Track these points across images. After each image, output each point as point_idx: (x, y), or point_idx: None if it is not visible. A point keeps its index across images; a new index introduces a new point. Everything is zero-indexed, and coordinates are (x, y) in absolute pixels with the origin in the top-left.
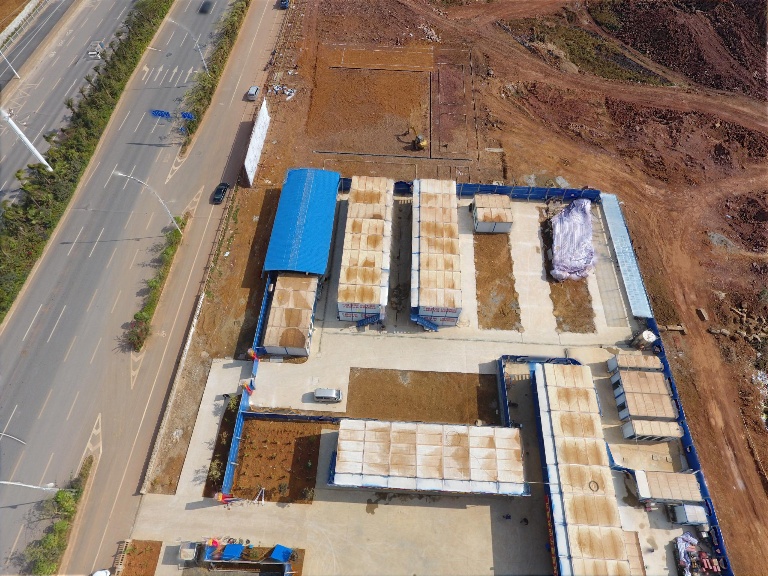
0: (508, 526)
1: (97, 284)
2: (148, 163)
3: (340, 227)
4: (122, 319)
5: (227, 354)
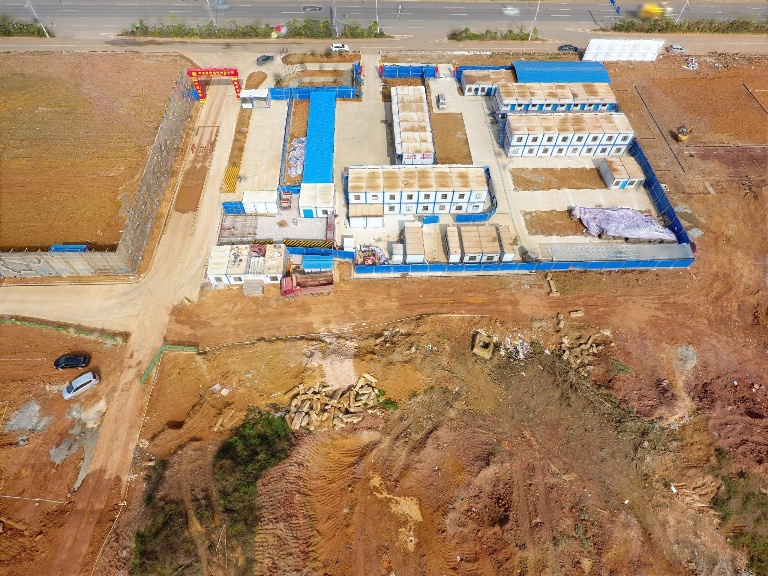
0: None
1: (483, 20)
2: (577, 20)
3: None
4: None
5: None
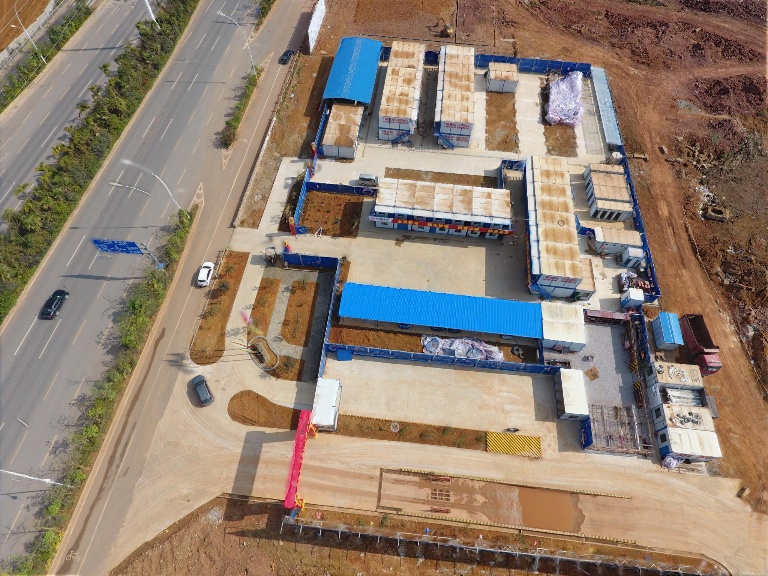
0: (498, 259)
1: (195, 108)
2: (229, 35)
3: (381, 83)
4: (215, 129)
5: (293, 155)
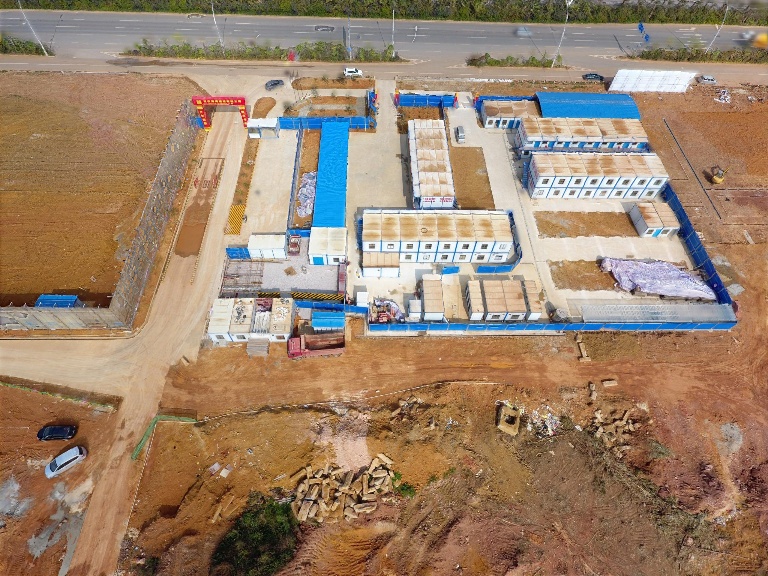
0: None
1: (503, 44)
2: (602, 45)
3: None
4: None
5: None
